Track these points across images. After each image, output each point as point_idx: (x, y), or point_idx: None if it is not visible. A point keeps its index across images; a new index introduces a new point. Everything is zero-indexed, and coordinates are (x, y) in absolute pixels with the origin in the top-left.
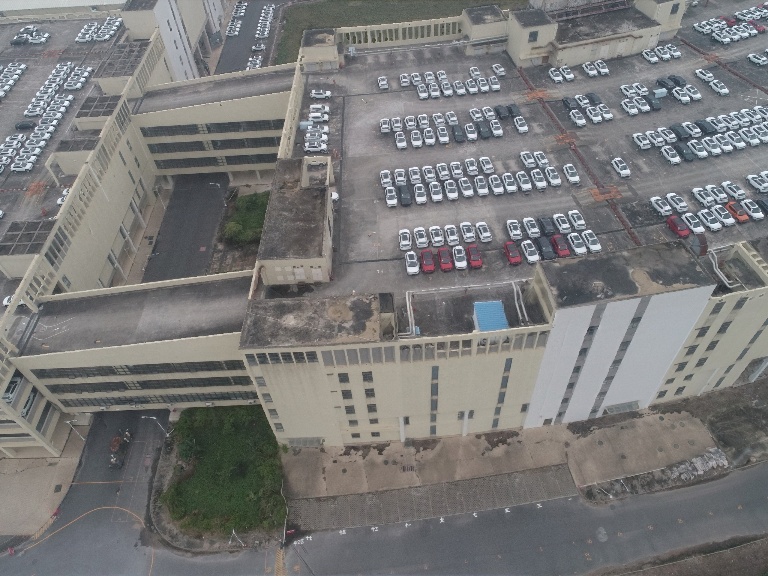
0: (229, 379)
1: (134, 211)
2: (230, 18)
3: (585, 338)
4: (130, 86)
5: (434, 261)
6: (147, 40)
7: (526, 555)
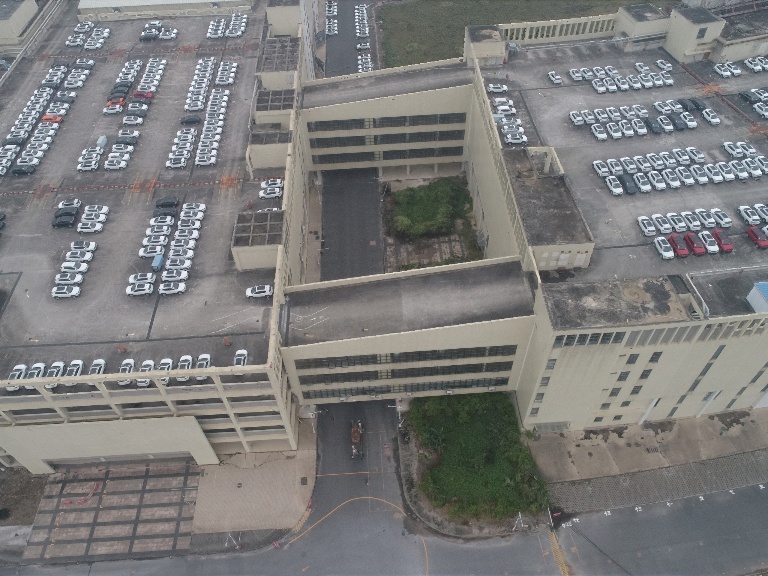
0: (483, 366)
1: (303, 206)
2: (324, 17)
3: None
4: (297, 80)
5: None
6: (288, 36)
7: None
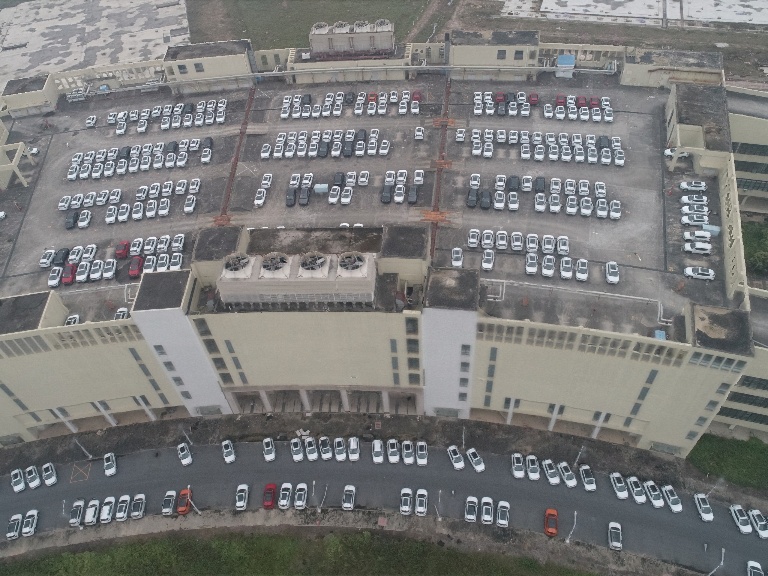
0: None
1: None
2: None
3: None
4: None
5: None
6: None
7: None
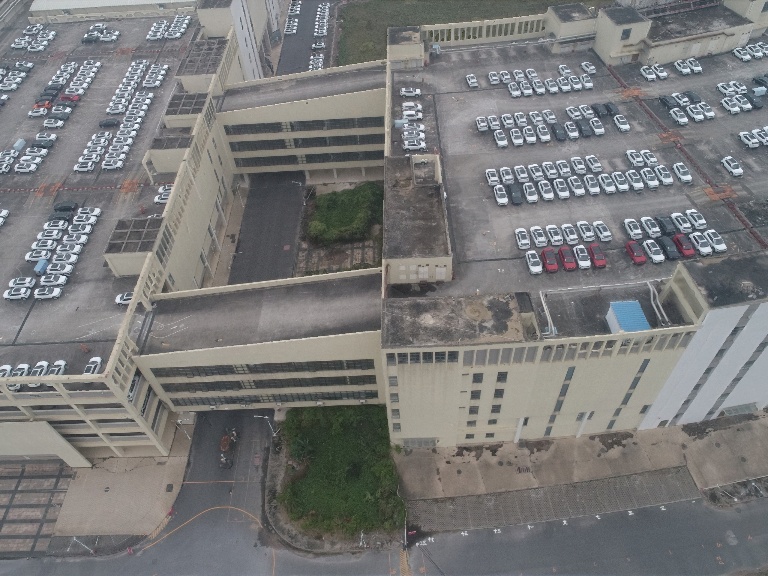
0: (346, 379)
1: (218, 209)
2: (286, 16)
3: (726, 339)
4: (214, 84)
5: (556, 260)
6: (221, 38)
7: (656, 558)
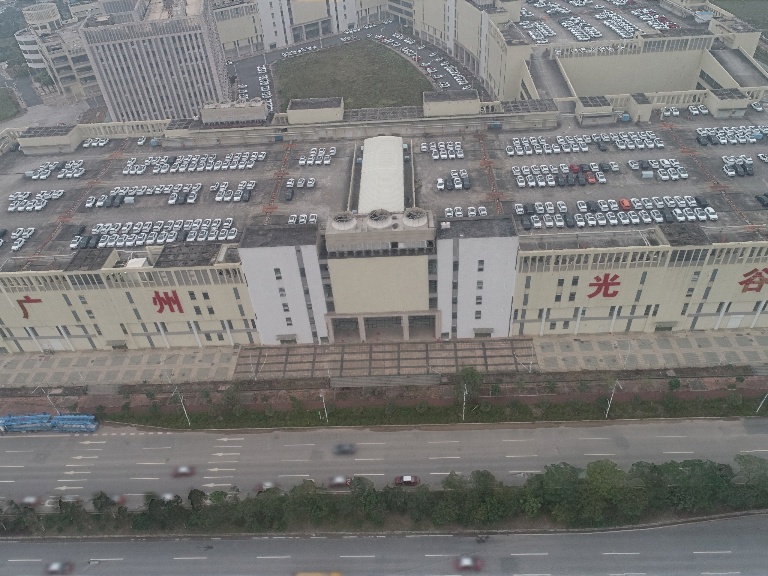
0: None
1: None
2: None
3: None
4: None
5: None
6: None
7: None
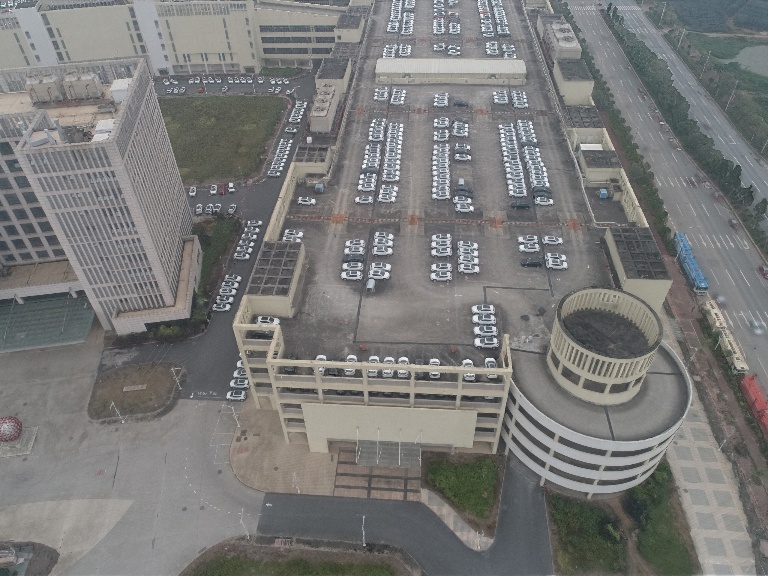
0: None
1: None
2: None
3: None
4: None
5: None
6: None
7: None
